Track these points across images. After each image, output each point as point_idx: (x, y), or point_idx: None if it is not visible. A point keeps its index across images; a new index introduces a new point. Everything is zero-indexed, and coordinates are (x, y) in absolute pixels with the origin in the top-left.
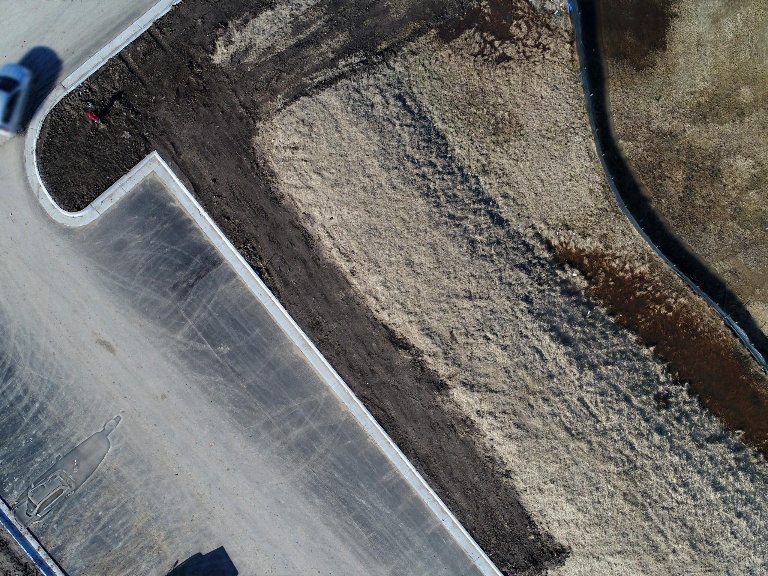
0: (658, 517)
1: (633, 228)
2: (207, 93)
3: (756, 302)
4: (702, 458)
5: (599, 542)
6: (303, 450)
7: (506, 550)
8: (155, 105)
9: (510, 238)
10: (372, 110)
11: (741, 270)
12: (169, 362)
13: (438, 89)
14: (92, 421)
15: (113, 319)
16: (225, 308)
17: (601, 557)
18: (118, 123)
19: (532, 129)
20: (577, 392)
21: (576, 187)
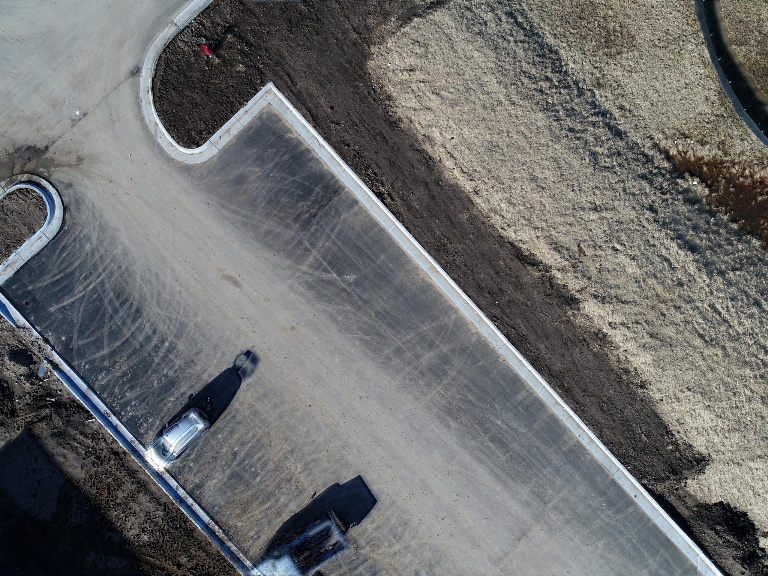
0: None
1: (751, 133)
2: (320, 21)
3: None
4: None
5: (739, 447)
6: (435, 374)
7: (644, 462)
8: (269, 36)
9: (630, 149)
10: (486, 28)
11: None
12: (296, 294)
13: (548, 5)
14: (222, 357)
15: (238, 254)
16: (349, 236)
17: (741, 462)
18: (233, 57)
19: (644, 39)
20: (708, 298)
21: (692, 95)
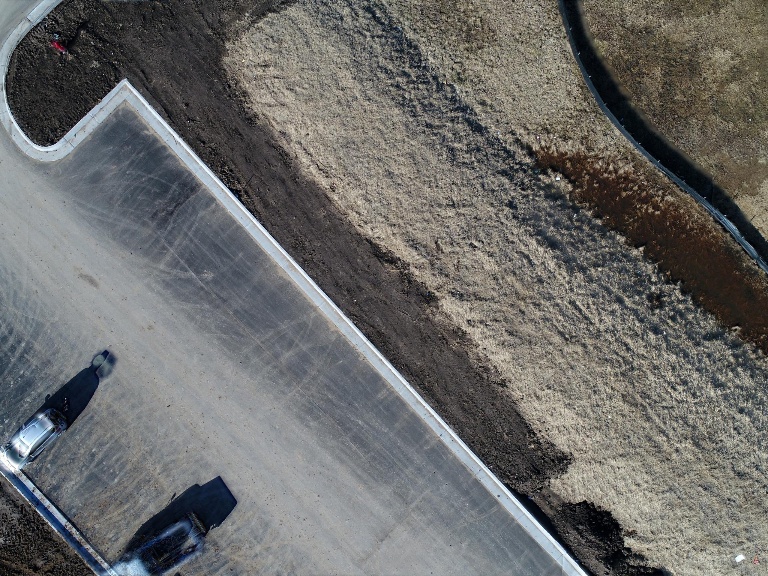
0: (658, 417)
1: (614, 128)
2: (174, 17)
3: (744, 195)
4: (699, 355)
5: (600, 446)
6: (294, 373)
7: (507, 461)
8: (122, 32)
9: (490, 145)
10: (342, 23)
11: (727, 163)
12: (153, 292)
13: None
14: (79, 357)
15: (94, 253)
16: (206, 234)
17: (603, 461)
18: (86, 53)
19: (505, 34)
20: (568, 295)
21: (554, 90)
